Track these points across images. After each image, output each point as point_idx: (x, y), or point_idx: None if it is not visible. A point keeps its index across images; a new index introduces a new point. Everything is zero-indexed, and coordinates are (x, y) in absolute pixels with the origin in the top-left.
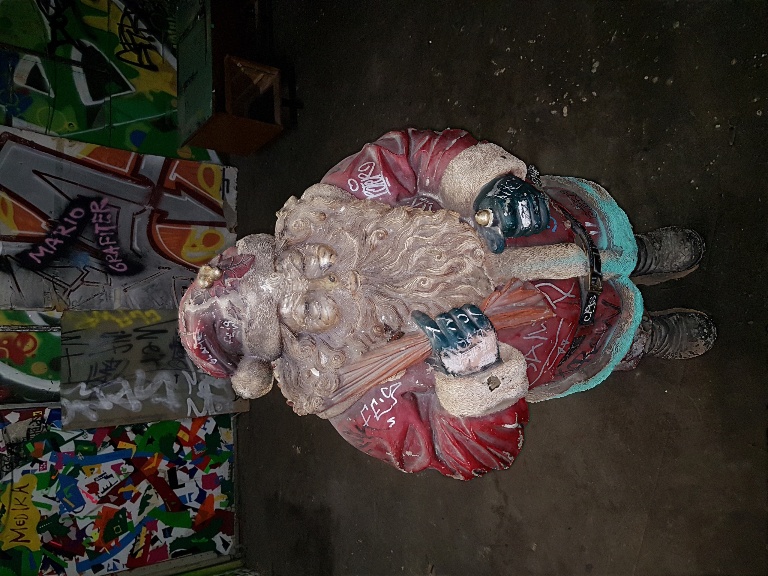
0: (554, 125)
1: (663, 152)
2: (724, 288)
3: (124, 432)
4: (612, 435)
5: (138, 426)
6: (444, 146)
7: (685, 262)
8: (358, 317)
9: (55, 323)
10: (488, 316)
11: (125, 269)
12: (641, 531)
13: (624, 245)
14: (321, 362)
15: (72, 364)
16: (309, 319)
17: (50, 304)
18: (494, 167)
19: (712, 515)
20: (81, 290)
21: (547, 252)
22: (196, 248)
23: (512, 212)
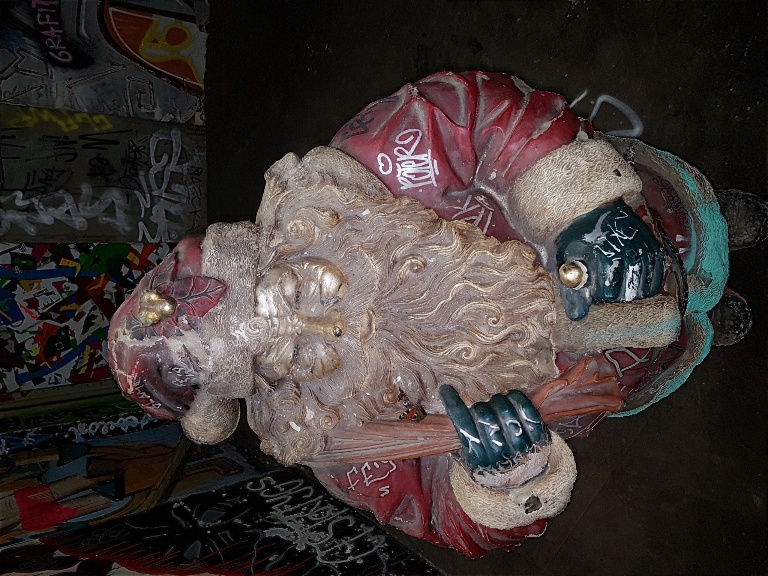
0: (630, 8)
1: (762, 88)
2: None
3: (67, 249)
4: None
5: (83, 244)
6: (530, 128)
7: (746, 242)
8: (365, 376)
9: None
10: (544, 412)
11: (69, 60)
12: (599, 485)
13: (715, 272)
14: (305, 419)
15: (5, 168)
16: (296, 369)
17: None
18: (601, 190)
19: (678, 494)
20: (15, 79)
21: (637, 316)
22: (157, 45)
23: (617, 282)
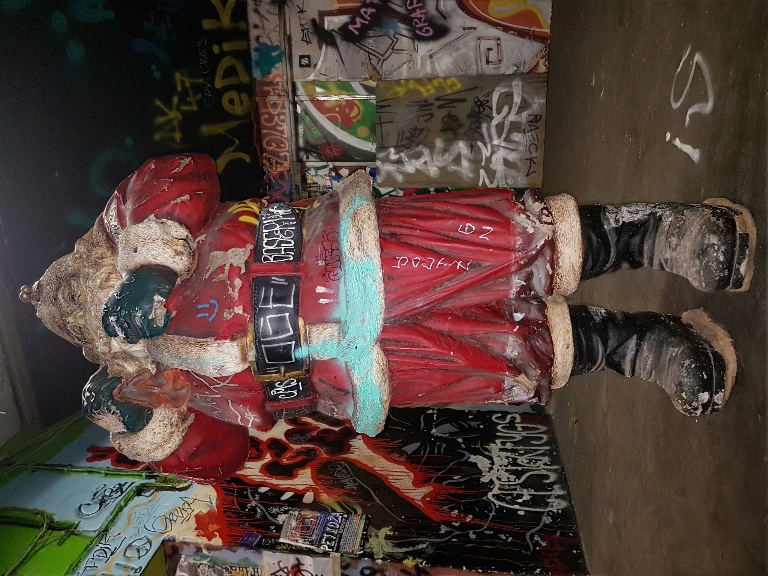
0: None
1: None
2: (759, 343)
3: (428, 192)
4: (660, 424)
5: (440, 188)
6: None
7: (694, 285)
8: None
9: (373, 92)
10: (123, 395)
11: (431, 33)
12: (651, 533)
13: (351, 326)
14: None
15: (384, 131)
16: None
17: (366, 75)
18: (124, 262)
19: None
20: (392, 59)
21: (179, 350)
22: (505, 0)
23: (105, 325)
